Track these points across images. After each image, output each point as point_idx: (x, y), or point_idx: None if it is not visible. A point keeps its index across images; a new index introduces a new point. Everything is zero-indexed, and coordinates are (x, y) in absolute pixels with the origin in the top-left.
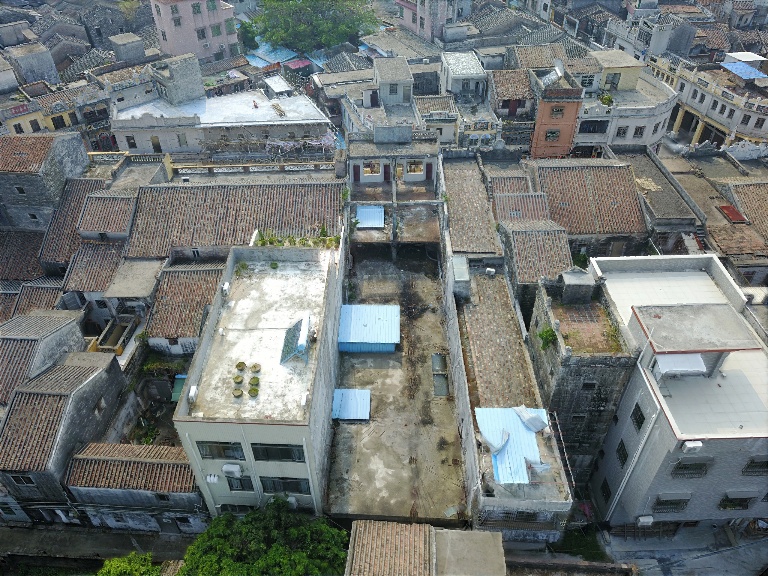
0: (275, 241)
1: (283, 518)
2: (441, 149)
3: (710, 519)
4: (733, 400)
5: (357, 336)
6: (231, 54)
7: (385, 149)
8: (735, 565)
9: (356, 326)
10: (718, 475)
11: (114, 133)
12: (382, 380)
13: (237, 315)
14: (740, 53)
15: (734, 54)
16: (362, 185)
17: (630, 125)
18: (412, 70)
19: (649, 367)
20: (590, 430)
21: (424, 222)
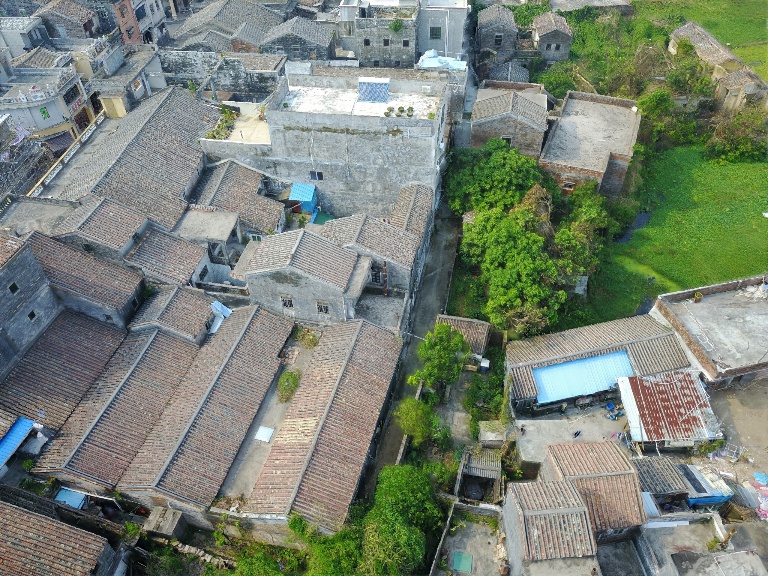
0: None
1: None
2: None
3: None
4: (442, 2)
5: None
6: None
7: (127, 72)
8: (466, 86)
9: None
10: None
11: None
12: None
13: None
14: None
15: None
16: None
17: (152, 2)
18: None
19: (427, 4)
20: None
21: (205, 96)
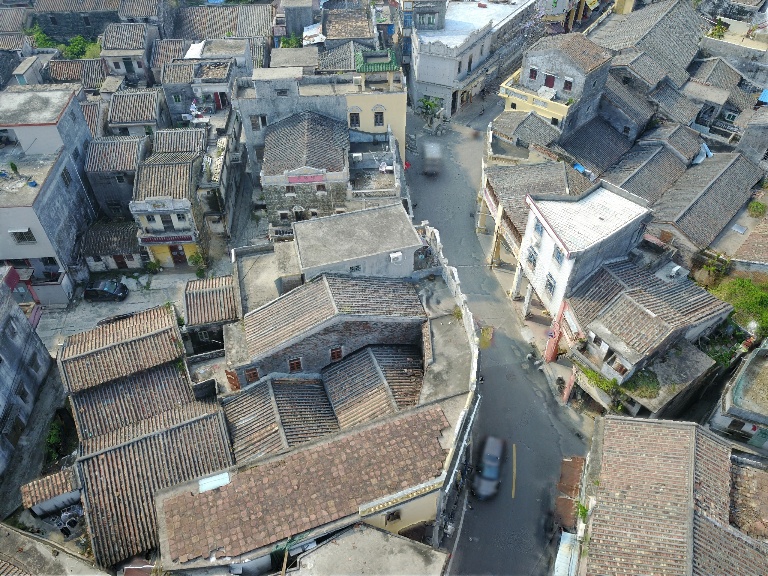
0: None
1: None
2: None
3: None
4: None
5: None
6: None
7: None
8: None
9: None
10: None
11: None
12: None
13: None
14: None
15: None
16: None
17: None
18: None
19: None
20: None
21: None
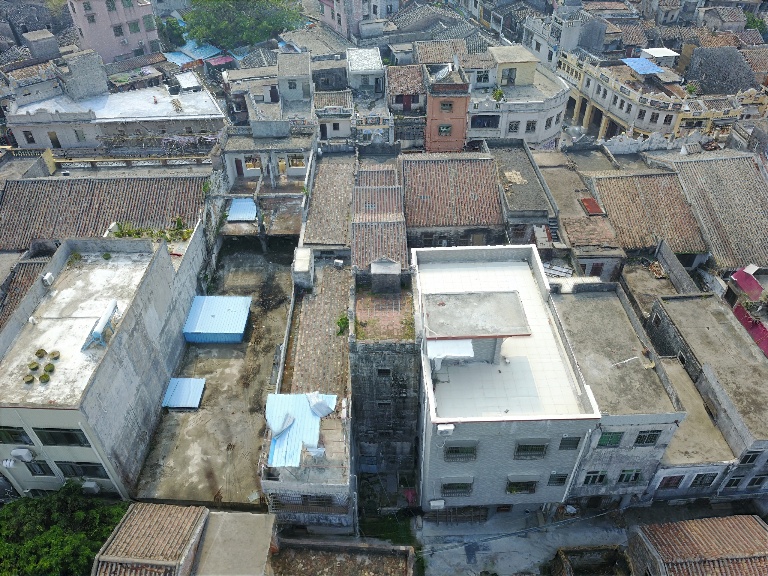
0: (133, 233)
1: (69, 501)
2: (320, 143)
3: (510, 504)
4: (508, 385)
5: (203, 326)
6: (152, 51)
7: (261, 143)
8: (540, 549)
9: (204, 317)
10: (493, 459)
11: (11, 128)
12: (222, 369)
13: (55, 304)
14: (656, 49)
15: (649, 50)
16: (245, 179)
17: (521, 120)
18: (321, 66)
19: None
20: (400, 417)
21: (296, 215)
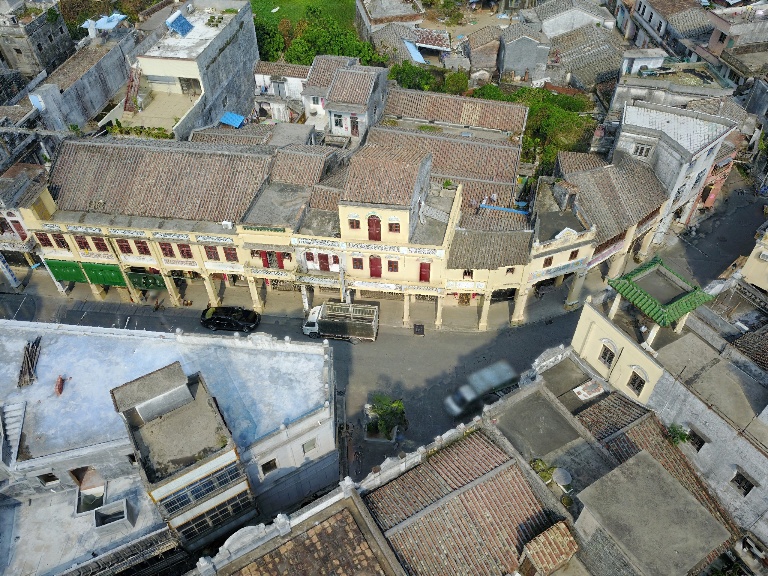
0: None
1: None
2: None
3: None
4: None
5: None
6: None
7: None
8: None
9: None
10: None
11: None
12: None
13: None
14: None
15: None
16: None
17: None
18: None
19: None
20: None
21: None
